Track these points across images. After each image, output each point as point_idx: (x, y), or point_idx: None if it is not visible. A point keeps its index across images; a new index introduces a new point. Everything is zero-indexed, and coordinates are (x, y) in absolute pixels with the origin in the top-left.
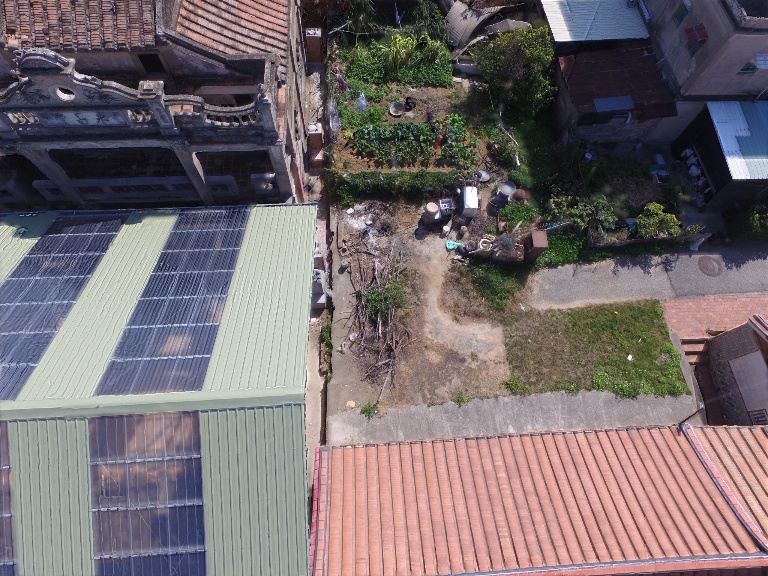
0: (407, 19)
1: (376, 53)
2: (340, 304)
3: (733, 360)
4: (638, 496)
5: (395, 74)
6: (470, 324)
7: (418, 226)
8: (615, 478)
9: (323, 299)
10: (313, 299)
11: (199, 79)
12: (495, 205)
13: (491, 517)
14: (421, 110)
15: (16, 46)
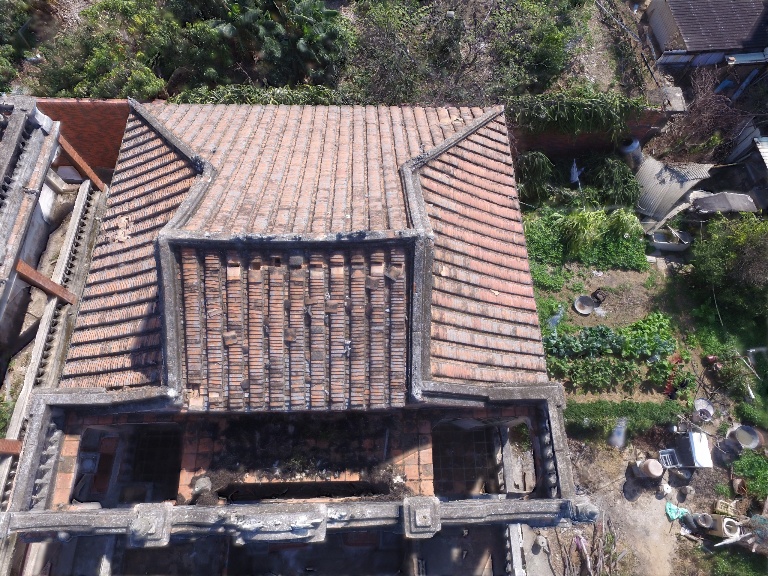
0: (588, 179)
1: (550, 222)
2: None
3: None
4: None
5: (576, 253)
6: None
7: (626, 479)
8: None
9: None
10: None
11: (437, 409)
12: (723, 451)
13: None
14: (613, 305)
15: (200, 408)
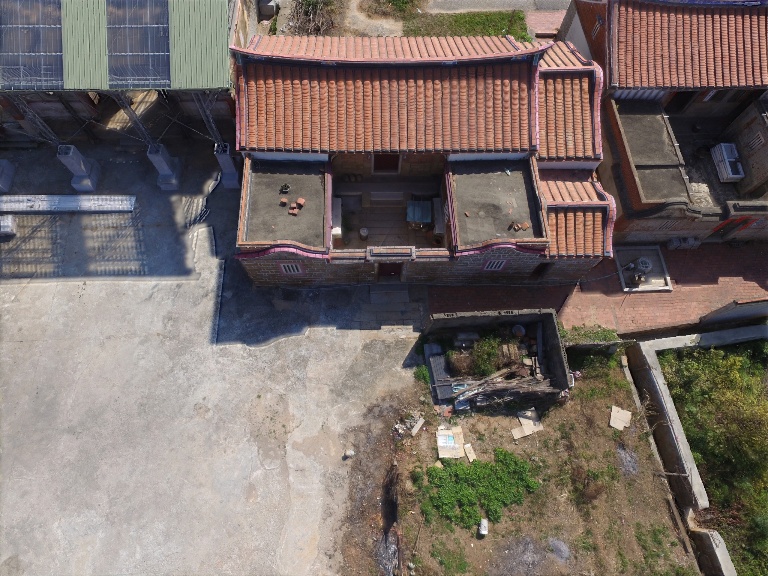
0: None
1: None
2: (284, 6)
3: (567, 35)
4: (462, 51)
5: None
6: (379, 19)
7: None
8: (450, 48)
9: (272, 3)
10: (265, 3)
11: None
12: None
13: (361, 56)
14: None
15: None
